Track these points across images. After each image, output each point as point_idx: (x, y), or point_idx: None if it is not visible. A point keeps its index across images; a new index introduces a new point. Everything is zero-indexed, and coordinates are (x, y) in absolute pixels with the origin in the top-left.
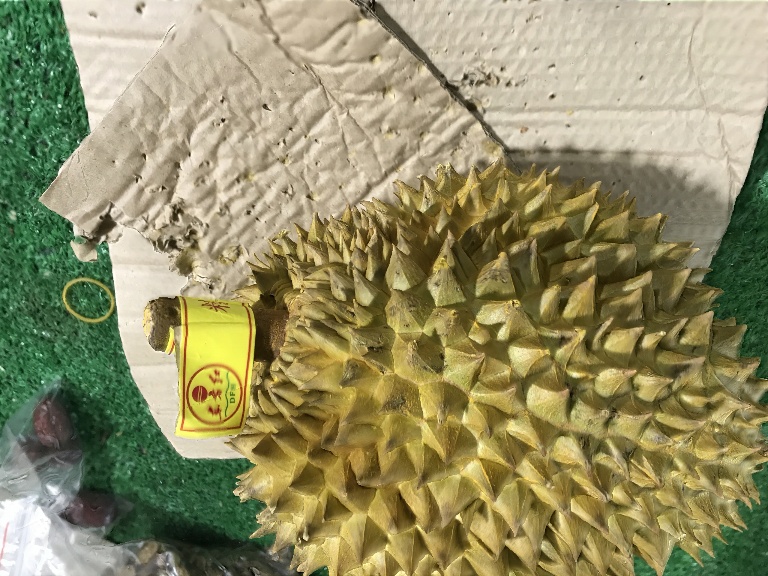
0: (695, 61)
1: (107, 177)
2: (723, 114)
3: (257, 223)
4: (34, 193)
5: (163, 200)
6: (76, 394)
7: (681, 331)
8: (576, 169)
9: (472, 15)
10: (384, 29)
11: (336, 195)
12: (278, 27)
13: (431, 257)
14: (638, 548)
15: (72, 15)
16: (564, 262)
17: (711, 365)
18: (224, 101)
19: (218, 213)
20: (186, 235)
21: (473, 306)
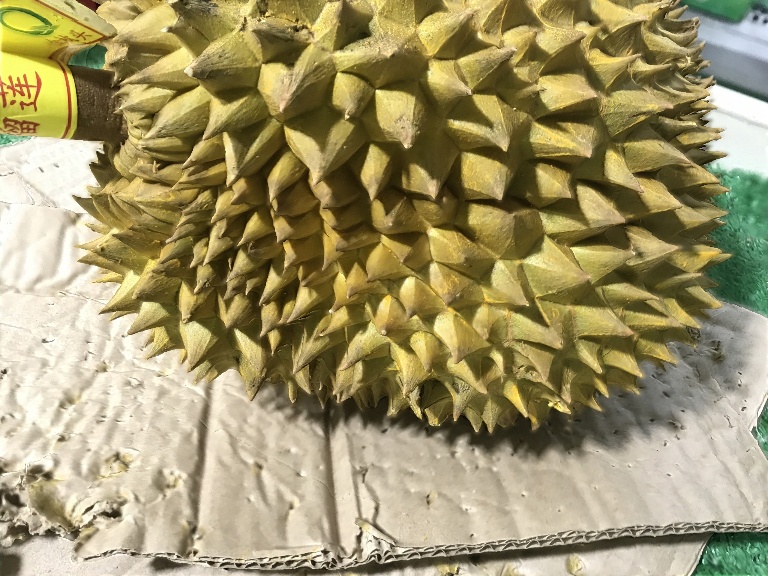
0: None
1: None
2: None
3: (121, 424)
4: None
5: None
6: None
7: None
8: None
9: None
10: None
11: None
12: (10, 278)
13: None
14: None
15: None
16: None
17: None
18: None
19: (60, 440)
20: (26, 471)
21: None
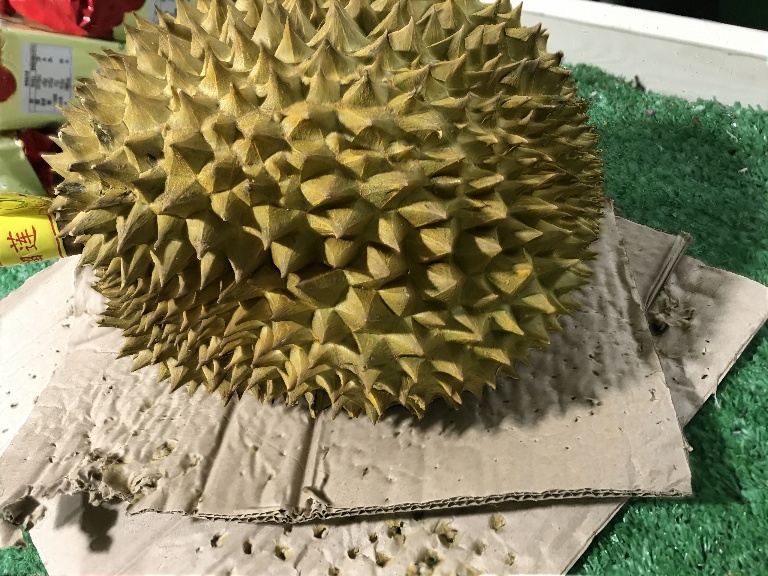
0: None
1: (21, 471)
2: None
3: (174, 421)
4: None
5: None
6: None
7: None
8: None
9: None
10: None
11: None
12: None
13: None
14: None
15: None
16: None
17: None
18: (106, 379)
19: (133, 435)
20: None
21: None
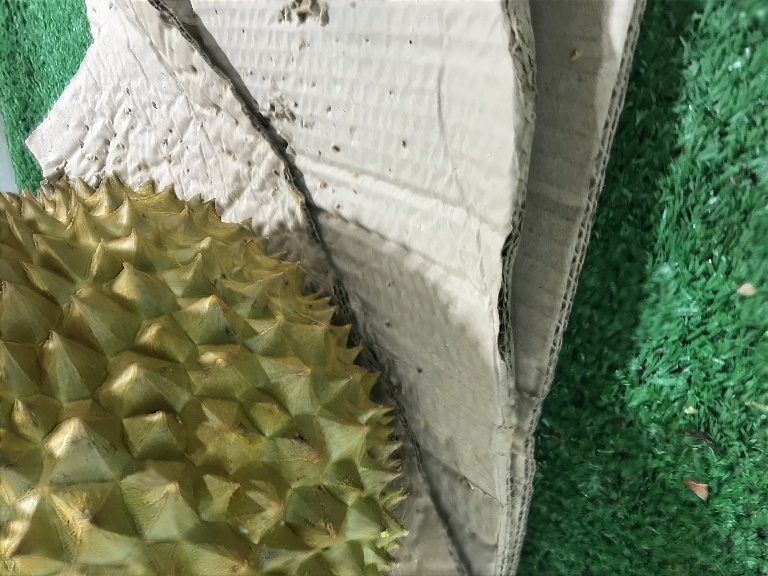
0: (447, 132)
1: (63, 137)
2: (480, 223)
3: None
4: None
5: (95, 168)
6: None
7: (54, 426)
8: (362, 251)
9: (260, 35)
10: (184, 37)
11: None
12: None
13: None
14: None
15: (89, 9)
16: None
17: (48, 488)
18: (130, 93)
19: None
20: None
21: None
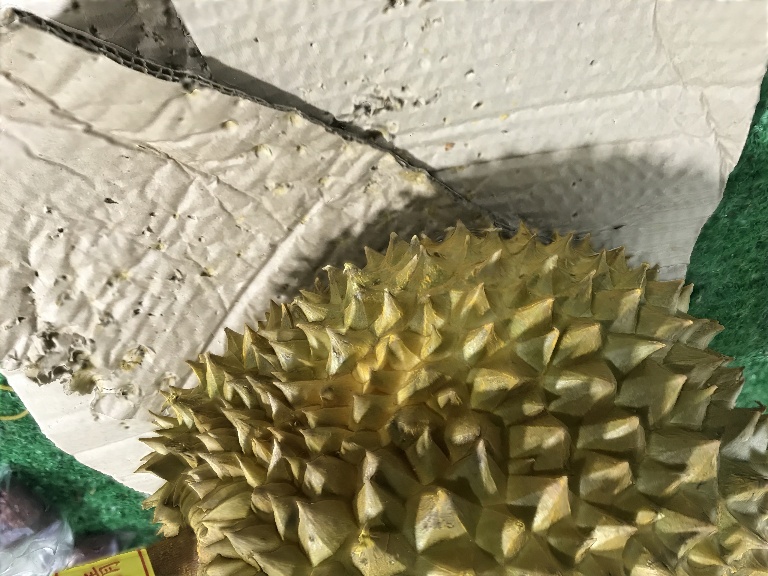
0: (663, 31)
1: None
2: (706, 87)
3: (152, 319)
4: None
5: (26, 331)
6: (31, 473)
7: (681, 467)
8: (524, 176)
9: (344, 38)
10: (226, 95)
11: (236, 264)
12: (81, 116)
13: (354, 463)
14: None
15: None
16: (525, 427)
17: (721, 497)
18: (51, 210)
19: (100, 324)
20: (70, 360)
21: (416, 574)
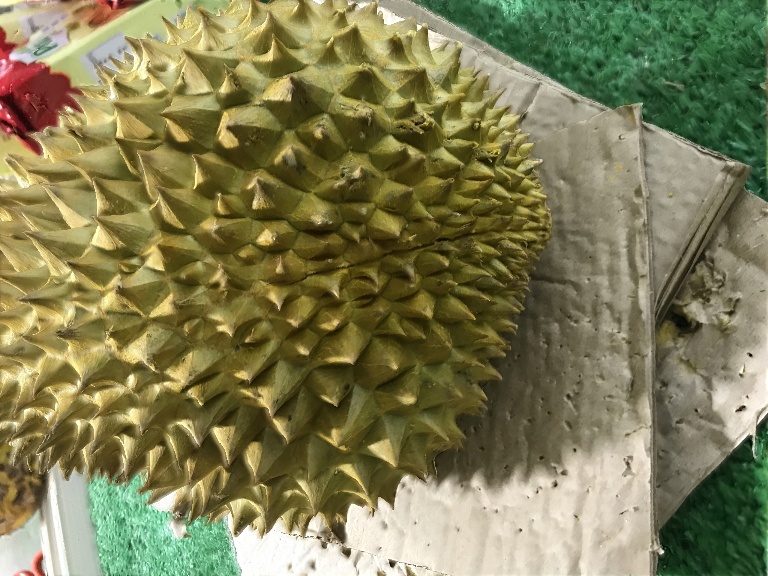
0: None
1: None
2: None
3: None
4: (218, 563)
5: None
6: None
7: None
8: None
9: None
10: None
11: None
12: None
13: None
14: (182, 142)
15: None
16: None
17: None
18: None
19: None
20: None
21: None
